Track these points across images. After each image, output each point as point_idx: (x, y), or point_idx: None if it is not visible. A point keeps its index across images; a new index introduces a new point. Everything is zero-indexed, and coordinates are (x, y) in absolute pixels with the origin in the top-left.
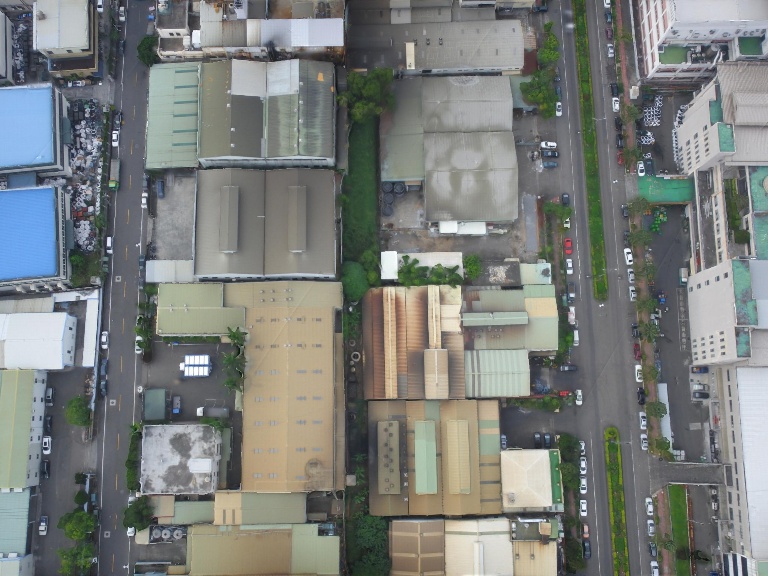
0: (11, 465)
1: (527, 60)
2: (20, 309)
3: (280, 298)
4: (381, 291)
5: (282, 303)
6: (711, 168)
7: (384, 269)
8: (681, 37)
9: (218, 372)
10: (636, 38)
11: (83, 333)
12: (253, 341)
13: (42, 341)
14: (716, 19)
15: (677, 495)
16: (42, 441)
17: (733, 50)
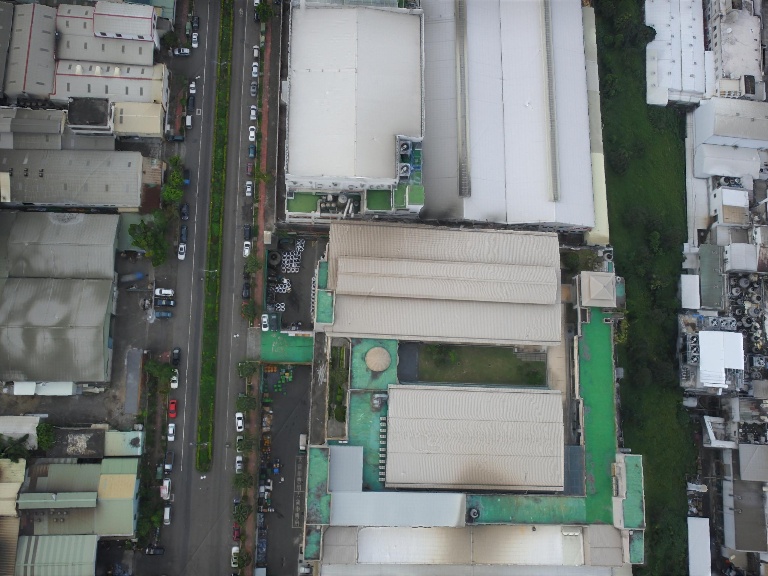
0: None
1: (147, 197)
2: None
3: None
4: None
5: None
6: None
7: None
8: (307, 186)
9: None
10: (283, 175)
11: None
12: None
13: None
14: (336, 172)
15: None
16: None
17: (364, 202)
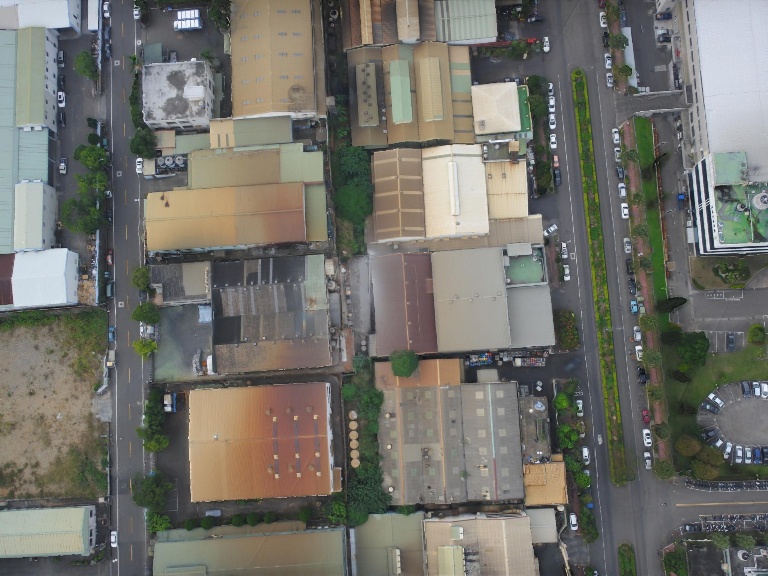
0: (30, 104)
1: None
2: None
3: None
4: None
5: None
6: None
7: None
8: None
9: (209, 30)
10: None
11: None
12: None
13: (50, 3)
14: None
15: (643, 127)
16: (57, 96)
17: None
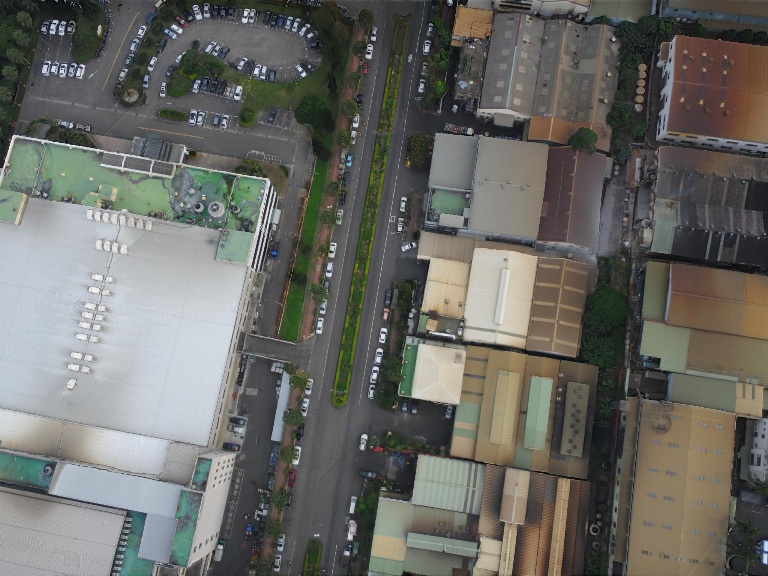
0: None
1: None
2: None
3: None
4: None
5: None
6: None
7: None
8: None
9: None
10: None
11: None
12: (716, 571)
13: None
14: None
15: (289, 331)
16: None
17: None
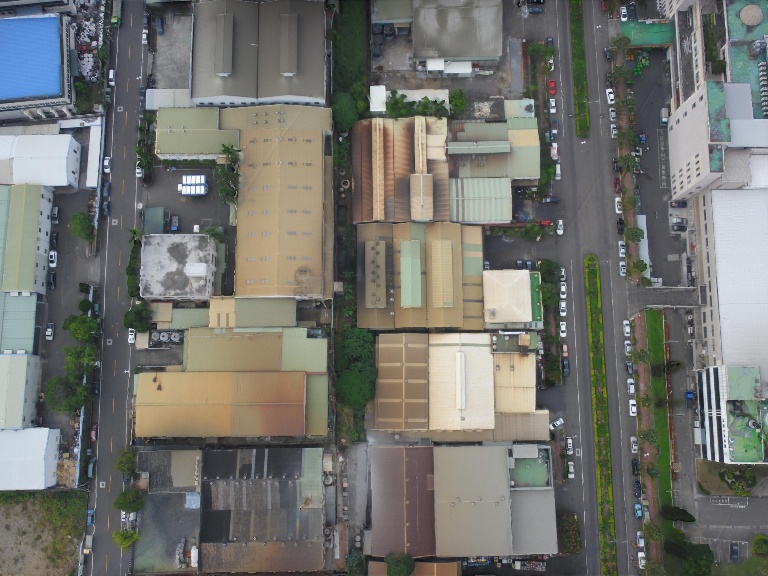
0: (19, 269)
1: None
2: (28, 134)
3: (272, 120)
4: (370, 122)
5: (274, 124)
6: (691, 6)
7: (373, 100)
8: None
9: (214, 194)
10: None
11: (87, 158)
12: (247, 160)
13: (48, 159)
14: None
15: (654, 319)
16: (48, 255)
17: None
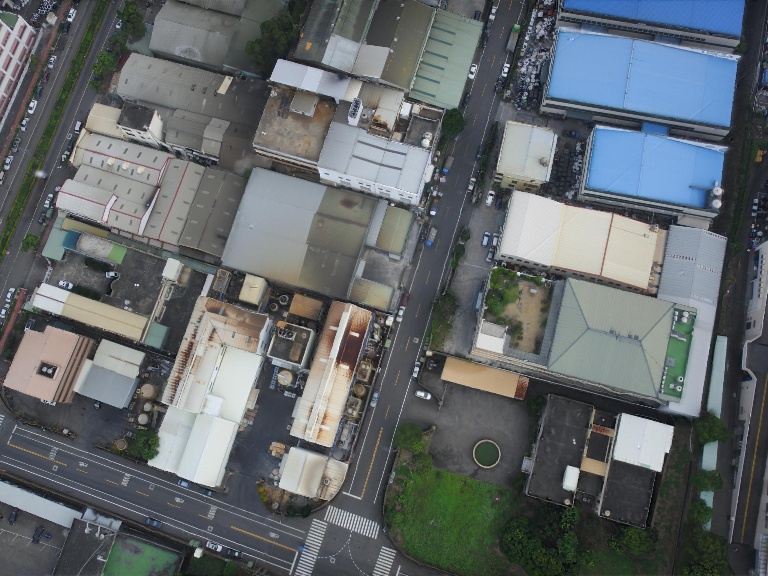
0: None
1: None
2: None
3: None
4: None
5: None
6: None
7: None
8: None
9: None
10: None
11: None
12: None
13: None
14: None
15: None
16: None
17: None
